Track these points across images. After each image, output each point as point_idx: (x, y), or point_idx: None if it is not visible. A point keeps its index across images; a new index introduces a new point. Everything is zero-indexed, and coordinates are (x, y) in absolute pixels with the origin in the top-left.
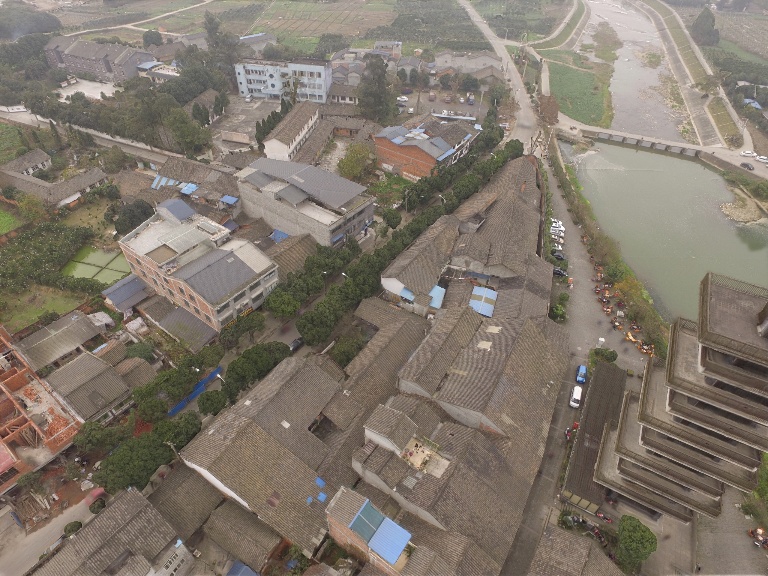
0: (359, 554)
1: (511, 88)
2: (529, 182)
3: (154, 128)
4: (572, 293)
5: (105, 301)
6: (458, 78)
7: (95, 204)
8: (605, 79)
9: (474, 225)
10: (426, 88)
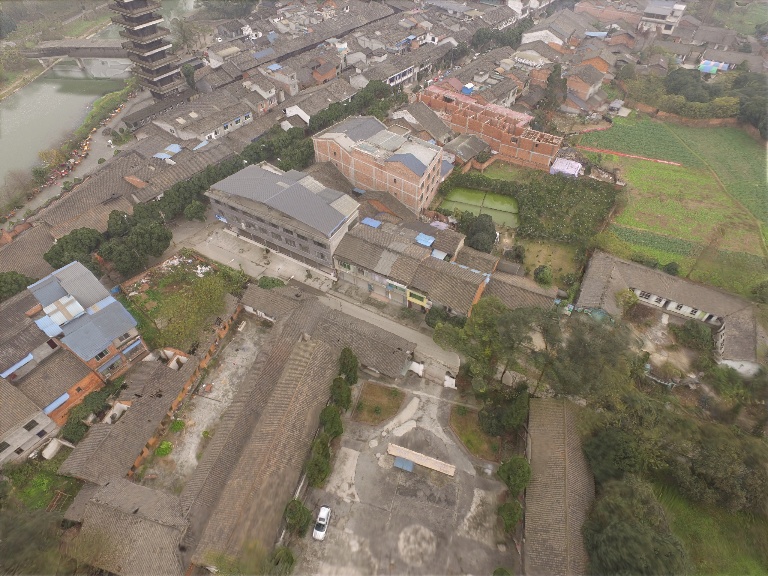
0: None
1: None
2: None
3: None
4: None
5: None
6: None
7: None
8: None
9: None
10: None
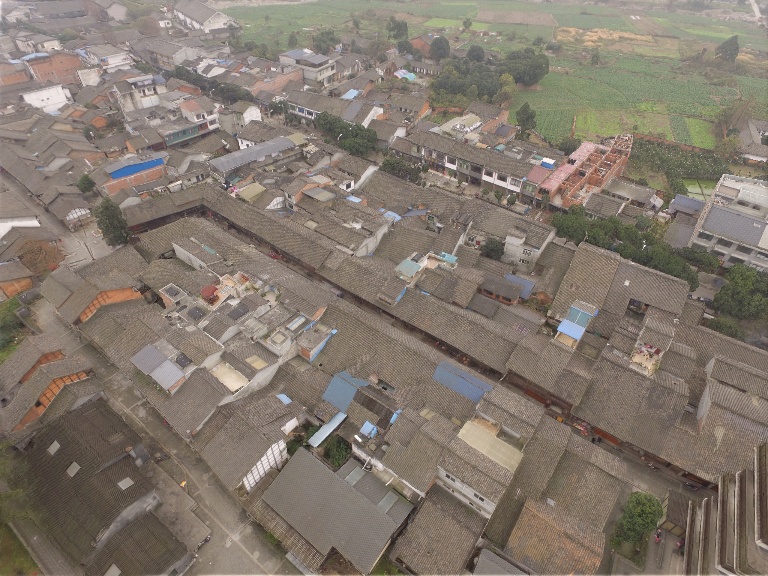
0: None
1: None
2: None
3: None
4: None
5: (673, 199)
6: None
7: (765, 172)
8: None
9: None
10: None
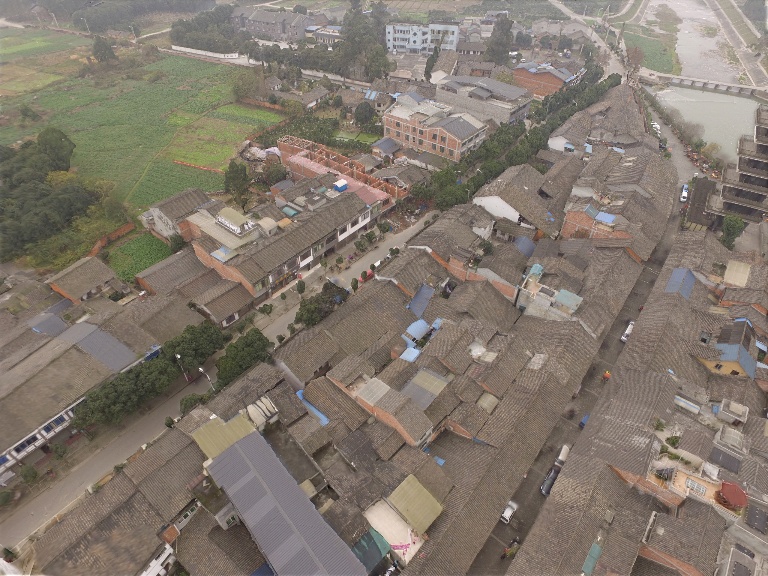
0: (582, 236)
1: (600, 46)
2: (630, 99)
3: (355, 62)
4: (671, 157)
5: (373, 151)
6: (556, 38)
7: (326, 109)
8: (671, 44)
9: (600, 117)
10: (529, 47)
